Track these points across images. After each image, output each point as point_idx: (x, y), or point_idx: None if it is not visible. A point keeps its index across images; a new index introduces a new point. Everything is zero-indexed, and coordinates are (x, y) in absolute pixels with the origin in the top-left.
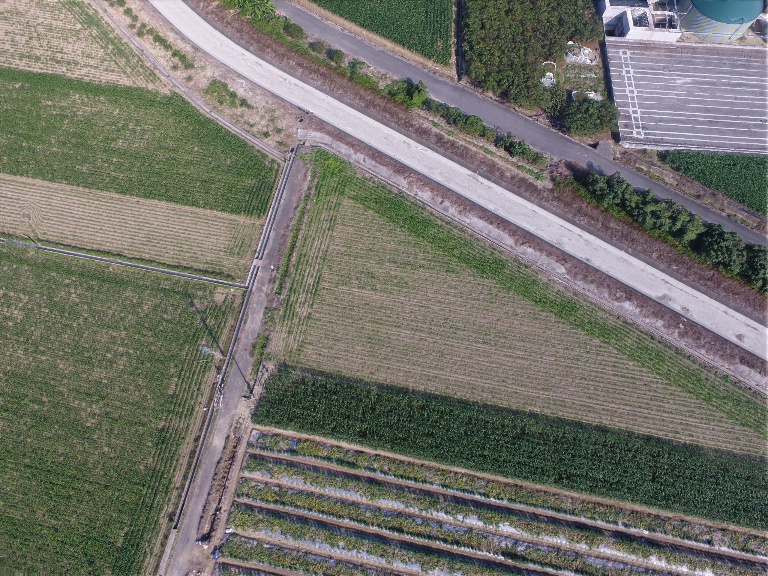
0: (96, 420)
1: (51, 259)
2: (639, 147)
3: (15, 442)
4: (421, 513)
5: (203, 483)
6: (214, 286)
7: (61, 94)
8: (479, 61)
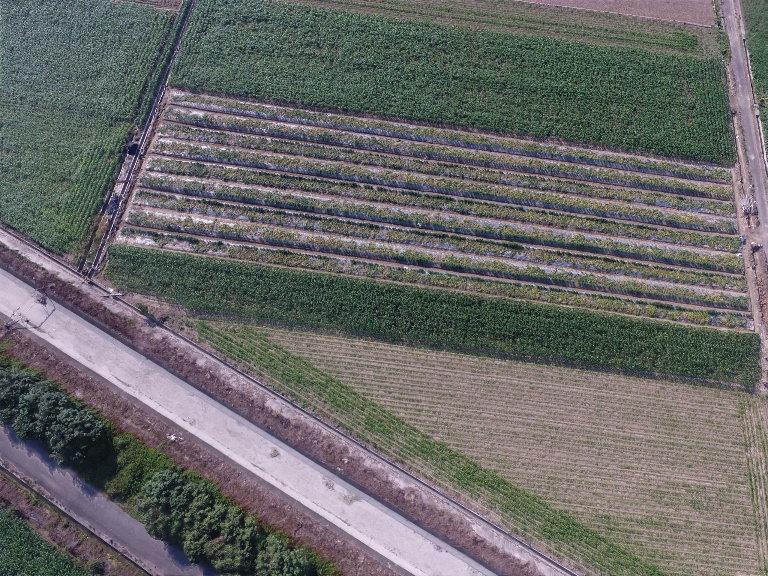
0: None
1: None
2: None
3: None
4: (591, 273)
5: None
6: None
7: None
8: None
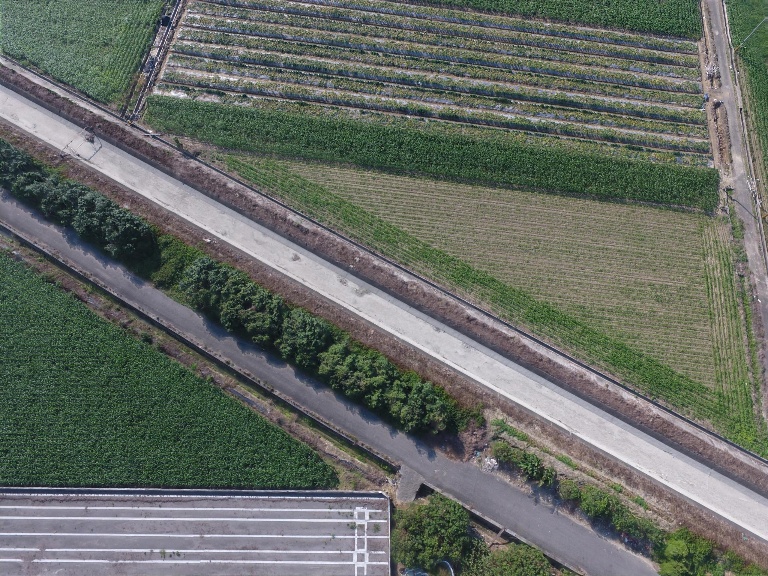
0: None
1: None
2: None
3: None
4: (571, 123)
5: (735, 133)
6: None
7: None
8: None
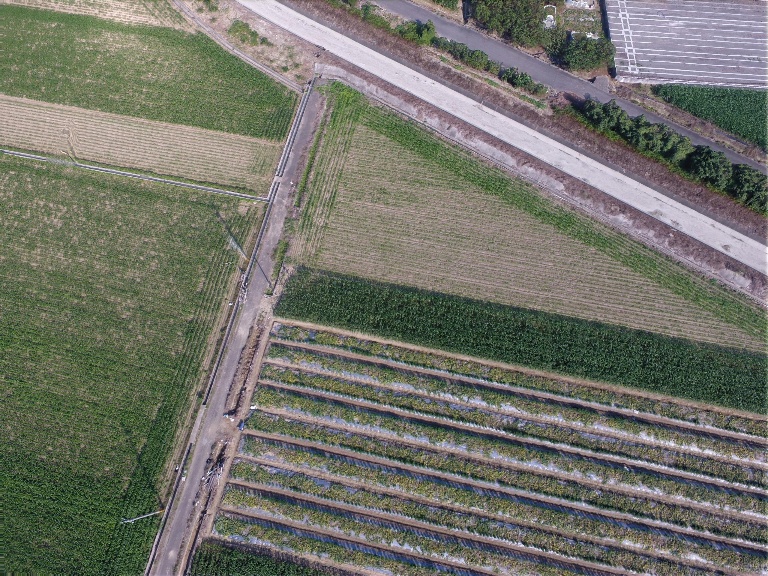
0: (131, 313)
1: (87, 175)
2: (634, 81)
3: (57, 330)
4: (429, 394)
5: (229, 366)
6: (238, 199)
7: (94, 33)
8: (484, 4)
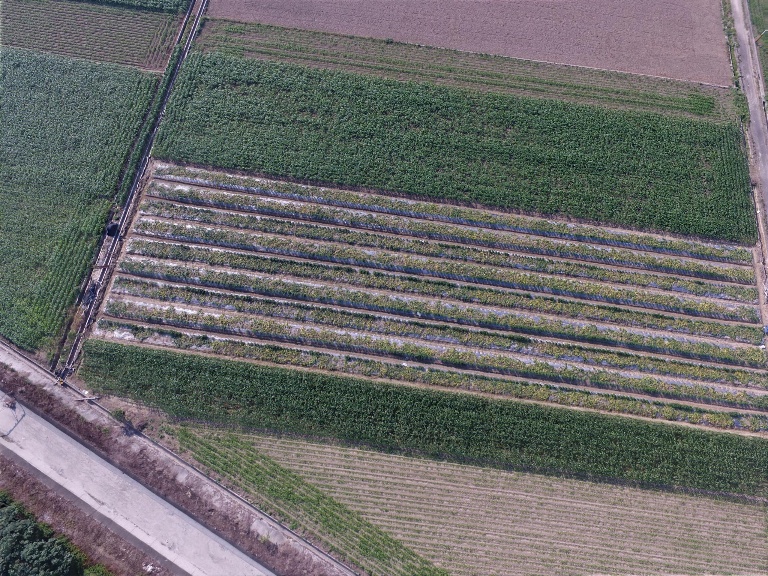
0: None
1: None
2: None
3: None
4: (604, 369)
5: None
6: None
7: None
8: None
